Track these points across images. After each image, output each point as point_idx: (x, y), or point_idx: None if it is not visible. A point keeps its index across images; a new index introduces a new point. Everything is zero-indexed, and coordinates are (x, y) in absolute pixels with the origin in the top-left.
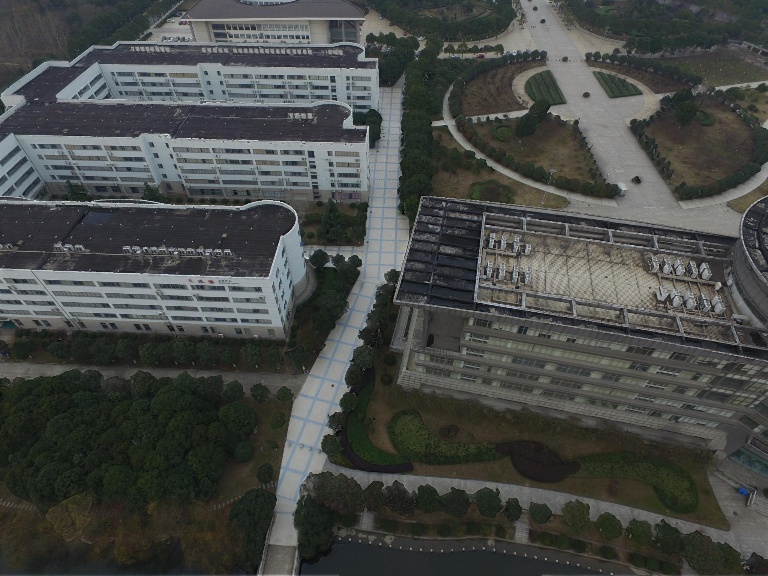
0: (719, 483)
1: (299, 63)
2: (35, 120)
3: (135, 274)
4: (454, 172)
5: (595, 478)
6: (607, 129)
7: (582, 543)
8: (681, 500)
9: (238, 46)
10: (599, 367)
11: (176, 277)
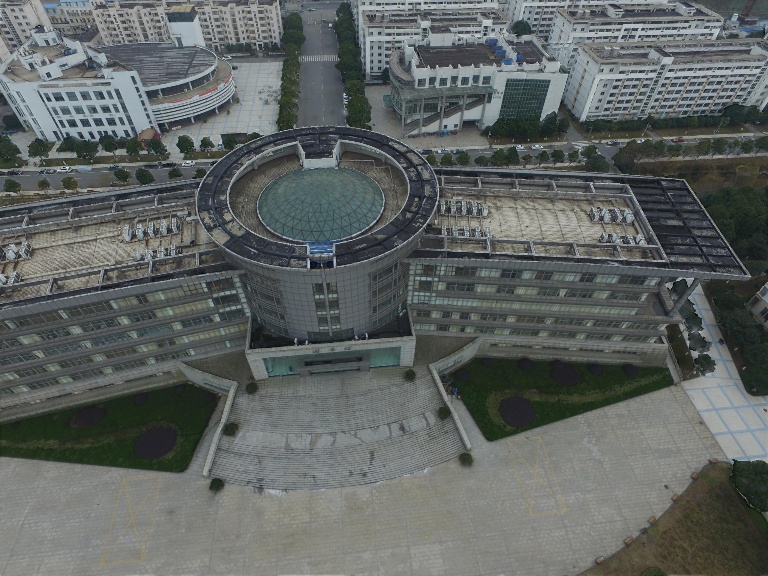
0: None
1: None
2: None
3: None
4: None
5: None
6: None
7: None
8: None
9: None
10: None
11: None
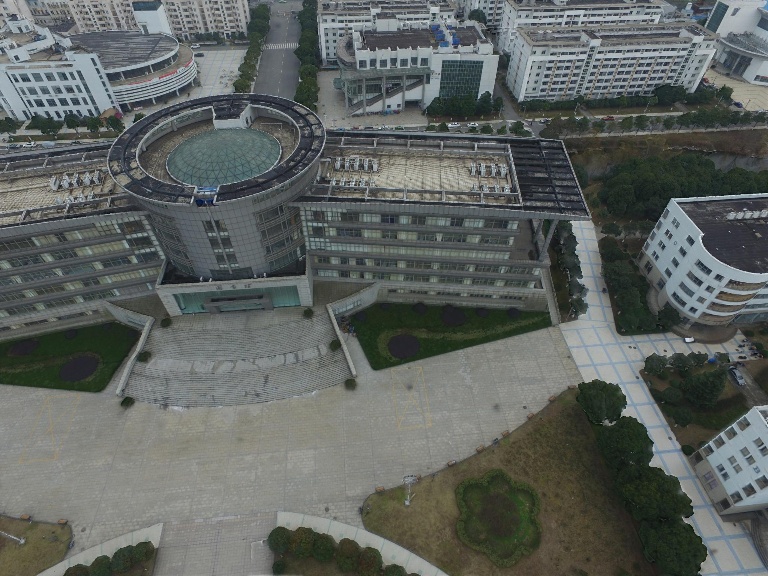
0: None
1: None
2: None
3: None
4: (586, 575)
5: None
6: None
7: None
8: None
9: None
10: None
11: (746, 196)
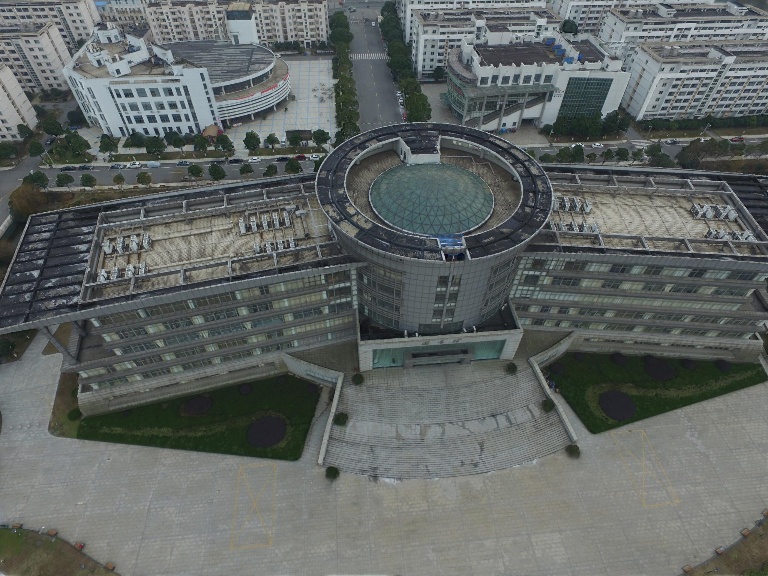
0: None
1: None
2: None
3: None
4: None
5: None
6: None
7: None
8: None
9: None
10: None
11: None
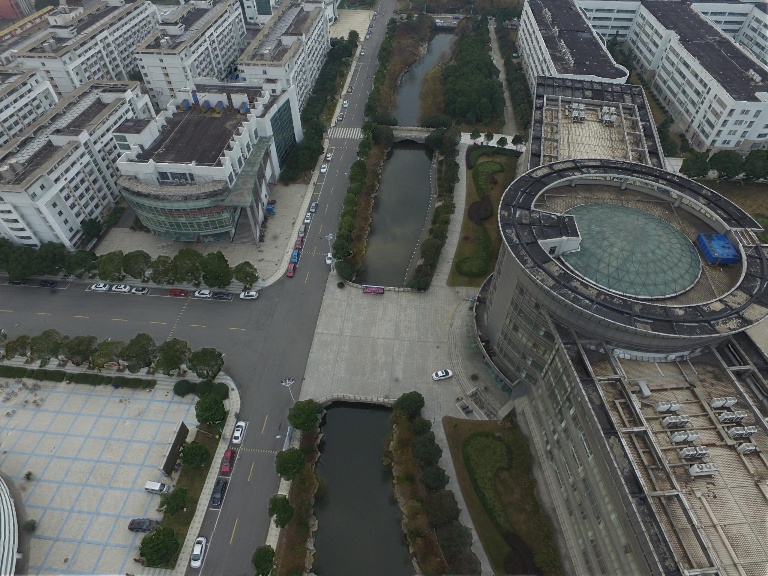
0: None
1: None
2: (664, 6)
3: (545, 45)
4: None
5: None
6: None
7: None
8: (463, 265)
9: None
10: None
11: None
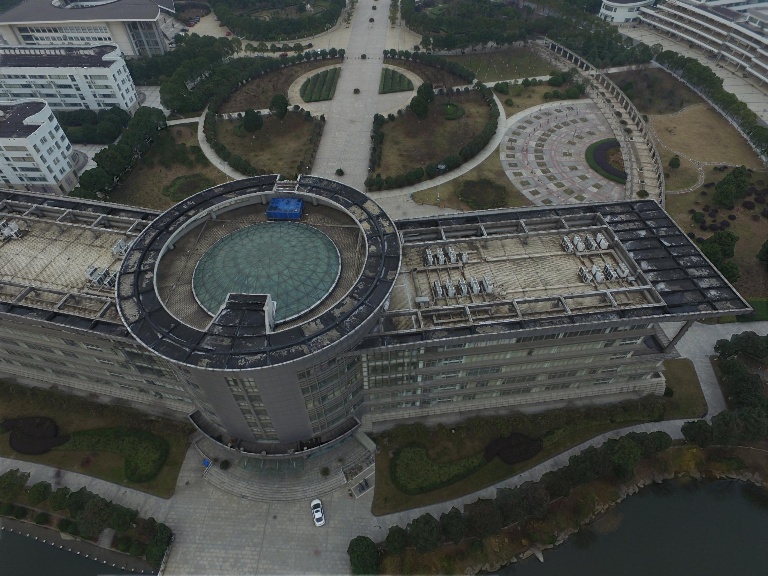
0: (194, 455)
1: (45, 63)
2: None
3: None
4: (166, 166)
5: (78, 451)
6: (352, 124)
7: (21, 510)
8: (140, 471)
9: (2, 47)
10: (42, 343)
11: None
